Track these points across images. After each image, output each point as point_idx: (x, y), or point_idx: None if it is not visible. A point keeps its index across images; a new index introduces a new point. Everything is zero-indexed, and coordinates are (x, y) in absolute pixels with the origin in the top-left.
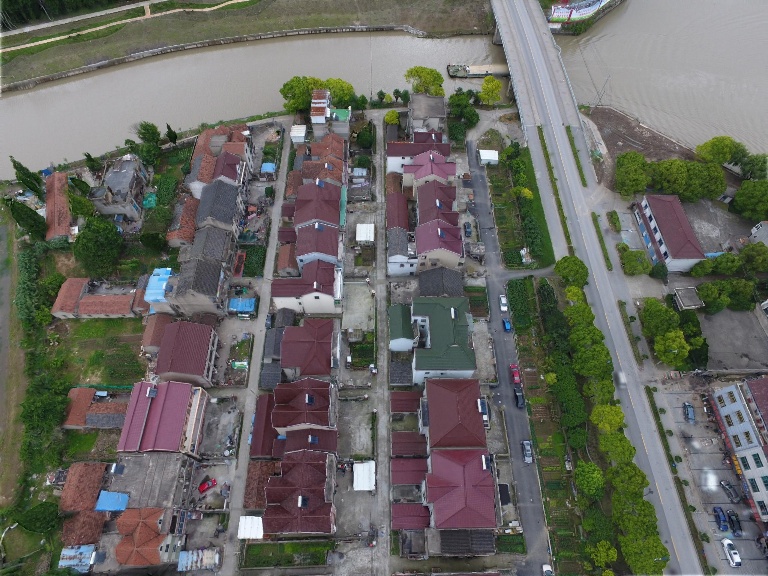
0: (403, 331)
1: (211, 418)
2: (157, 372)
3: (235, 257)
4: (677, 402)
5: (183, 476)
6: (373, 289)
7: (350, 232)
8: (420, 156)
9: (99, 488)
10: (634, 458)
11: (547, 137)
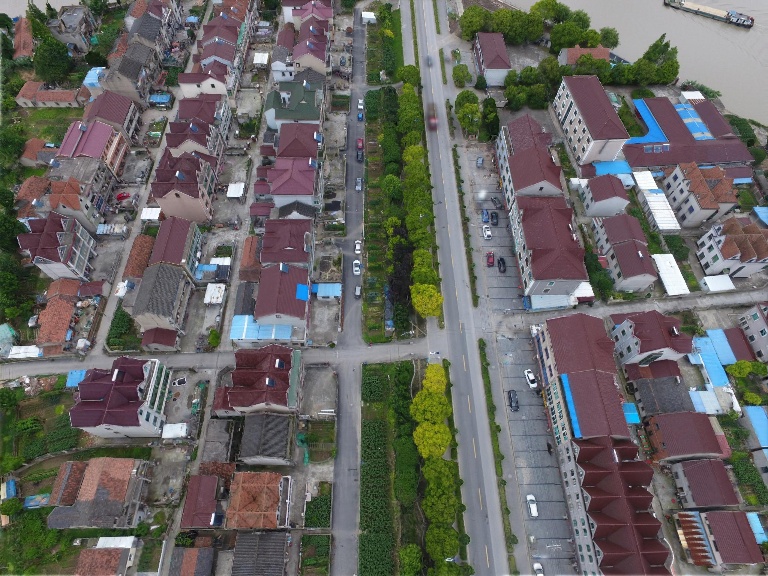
0: (273, 105)
1: (130, 163)
2: (88, 119)
3: (159, 74)
4: (474, 157)
5: (102, 176)
6: (263, 95)
7: (251, 61)
8: (306, 5)
9: (44, 192)
10: (433, 185)
11: (416, 3)
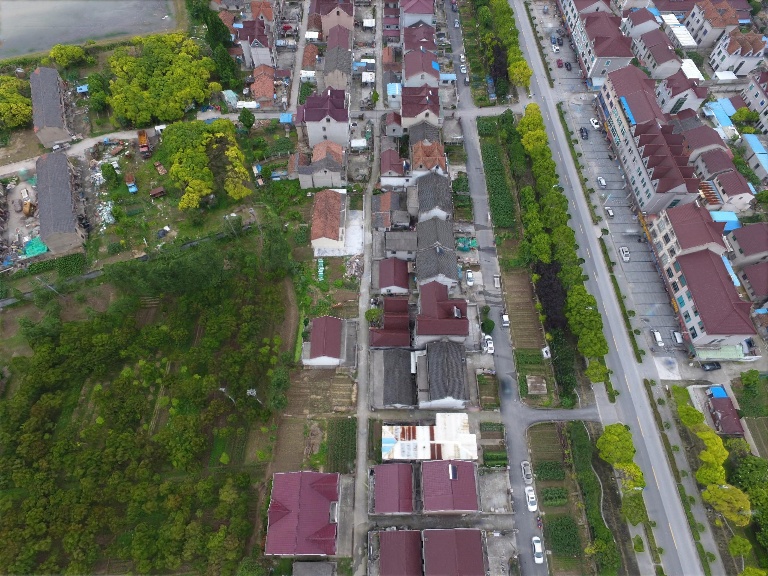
0: None
1: (286, 10)
2: None
3: None
4: (541, 8)
5: (278, 7)
6: None
7: None
8: None
9: (232, 22)
10: None
11: None
